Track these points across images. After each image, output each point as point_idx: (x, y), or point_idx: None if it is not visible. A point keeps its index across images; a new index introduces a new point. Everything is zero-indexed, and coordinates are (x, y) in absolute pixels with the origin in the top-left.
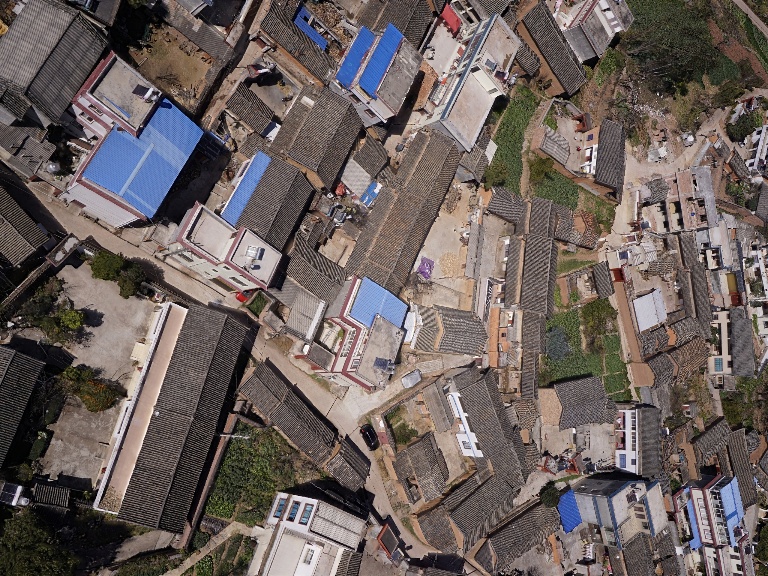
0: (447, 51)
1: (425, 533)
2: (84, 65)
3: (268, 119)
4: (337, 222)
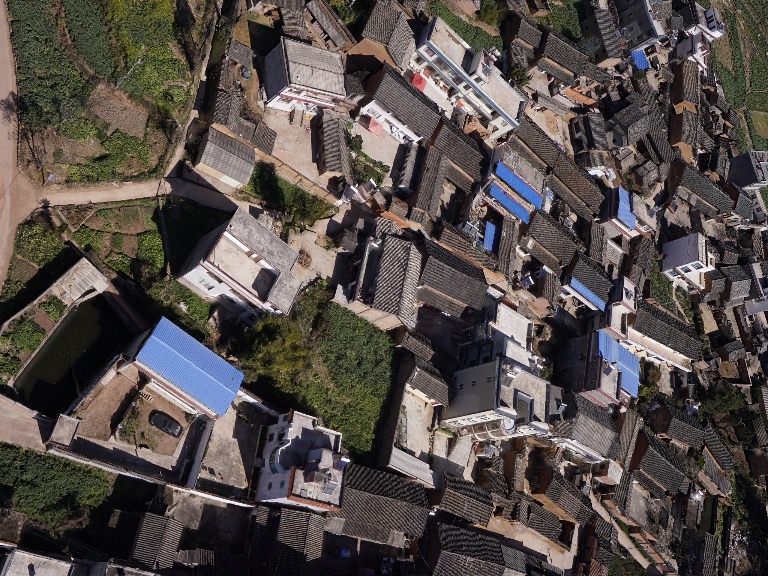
0: (430, 90)
1: (664, 179)
2: (586, 403)
3: (556, 278)
4: (568, 224)
